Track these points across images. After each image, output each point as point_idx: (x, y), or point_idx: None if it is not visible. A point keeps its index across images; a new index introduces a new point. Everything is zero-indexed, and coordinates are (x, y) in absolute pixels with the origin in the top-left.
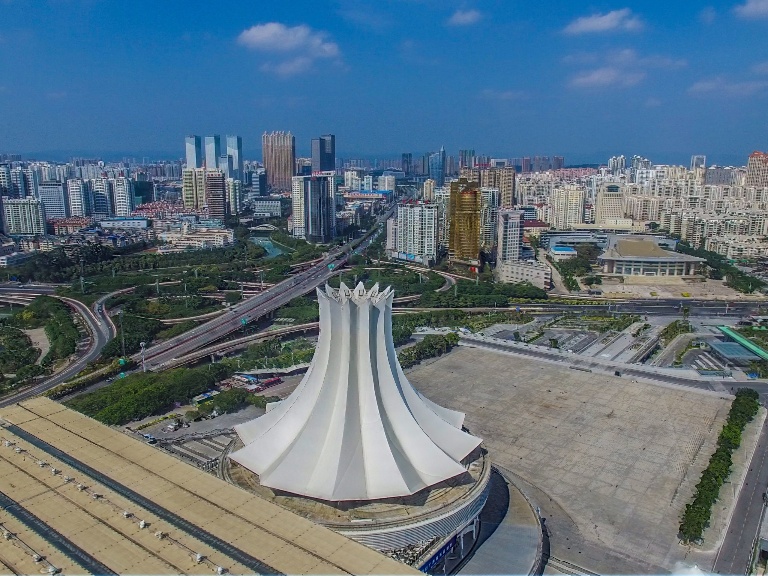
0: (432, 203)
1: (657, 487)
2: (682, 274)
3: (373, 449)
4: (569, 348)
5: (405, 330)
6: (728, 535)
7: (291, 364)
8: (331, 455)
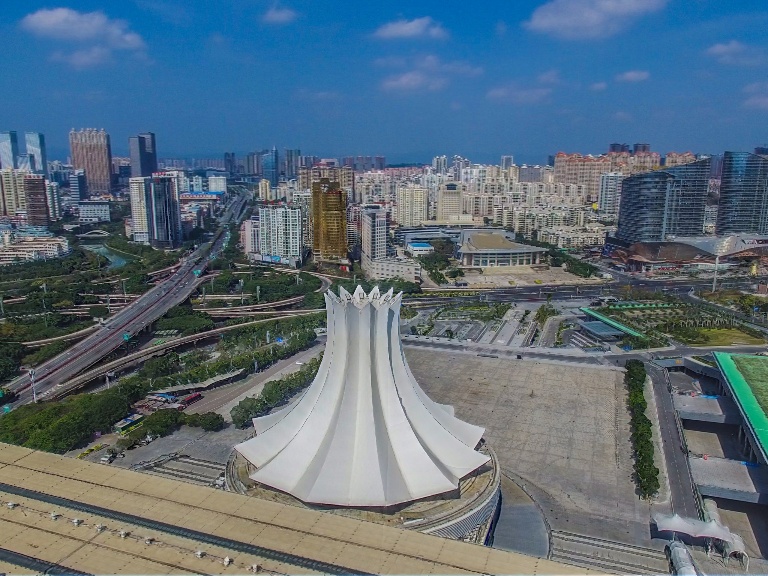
0: (295, 204)
1: (600, 453)
2: (530, 263)
3: (404, 450)
4: (462, 338)
5: (310, 333)
6: (672, 486)
7: (207, 378)
8: (367, 461)
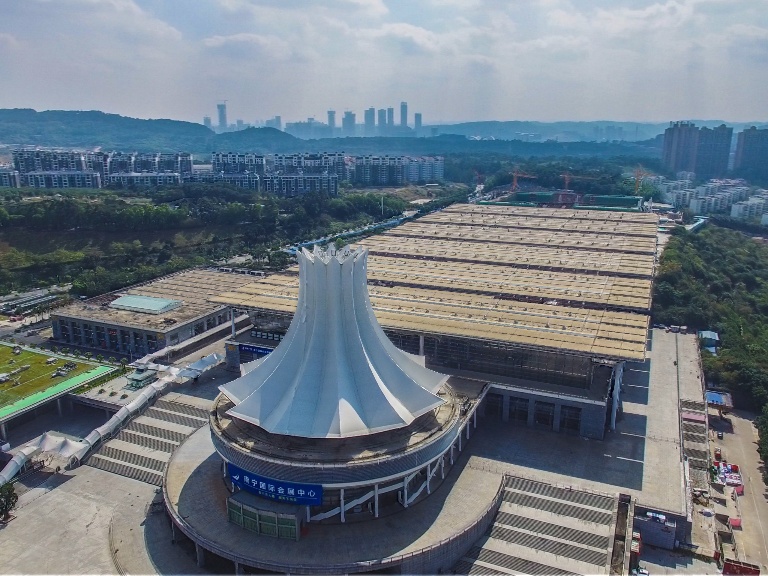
0: None
1: None
2: None
3: None
4: None
5: None
6: None
7: None
8: None
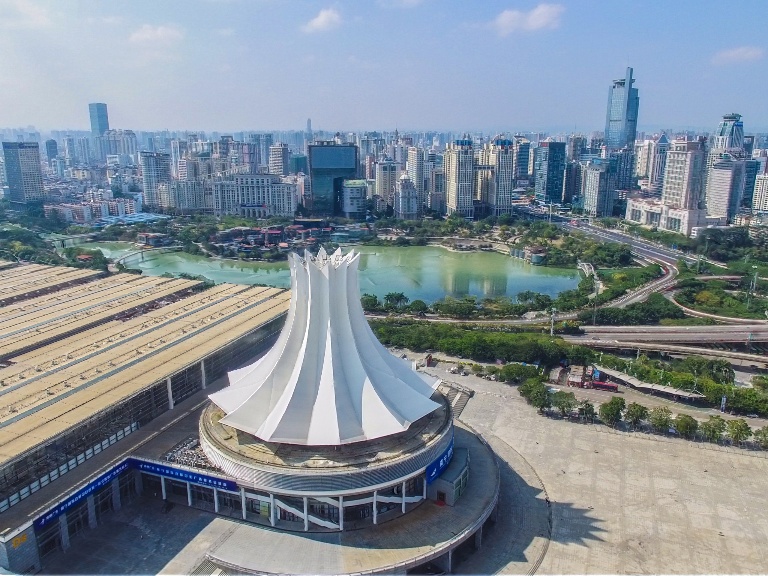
0: None
1: None
2: None
3: None
4: None
5: None
6: None
7: (654, 381)
8: None
